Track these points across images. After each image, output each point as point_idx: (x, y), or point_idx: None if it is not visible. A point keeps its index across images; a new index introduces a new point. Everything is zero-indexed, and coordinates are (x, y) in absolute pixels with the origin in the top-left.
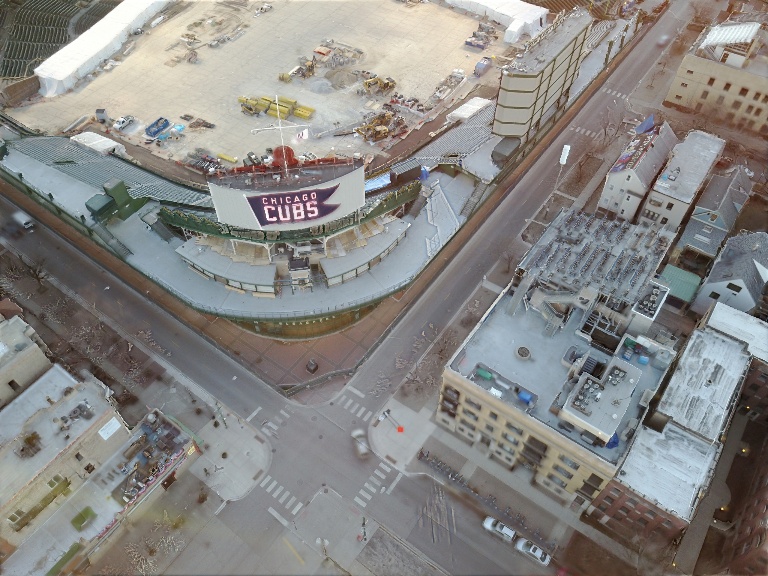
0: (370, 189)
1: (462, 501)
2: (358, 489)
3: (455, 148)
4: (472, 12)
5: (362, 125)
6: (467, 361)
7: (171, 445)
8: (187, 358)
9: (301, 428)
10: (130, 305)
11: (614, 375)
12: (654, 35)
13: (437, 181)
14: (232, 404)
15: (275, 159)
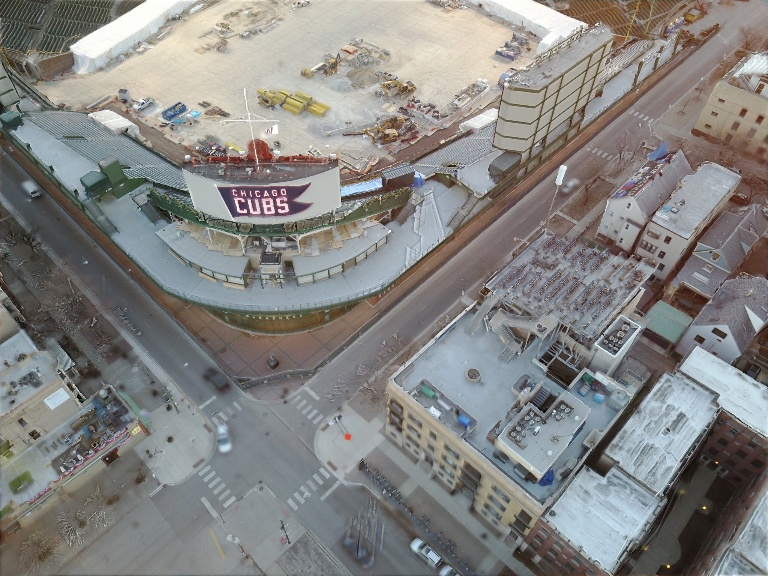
0: (360, 191)
1: (395, 518)
2: (293, 491)
3: (457, 158)
4: (510, 21)
5: (373, 127)
6: (414, 376)
7: (117, 422)
8: (155, 339)
9: (250, 422)
10: (113, 281)
11: (560, 410)
12: (697, 59)
13: (431, 190)
14: (189, 390)
15: (250, 152)
